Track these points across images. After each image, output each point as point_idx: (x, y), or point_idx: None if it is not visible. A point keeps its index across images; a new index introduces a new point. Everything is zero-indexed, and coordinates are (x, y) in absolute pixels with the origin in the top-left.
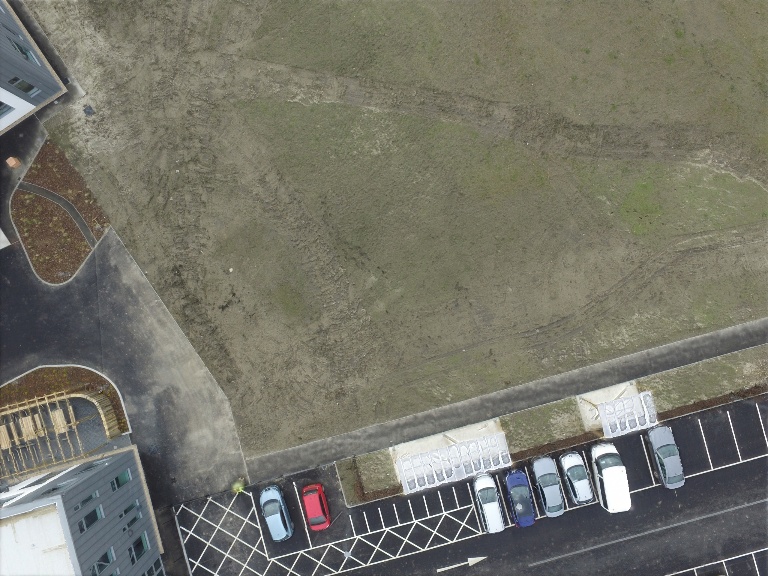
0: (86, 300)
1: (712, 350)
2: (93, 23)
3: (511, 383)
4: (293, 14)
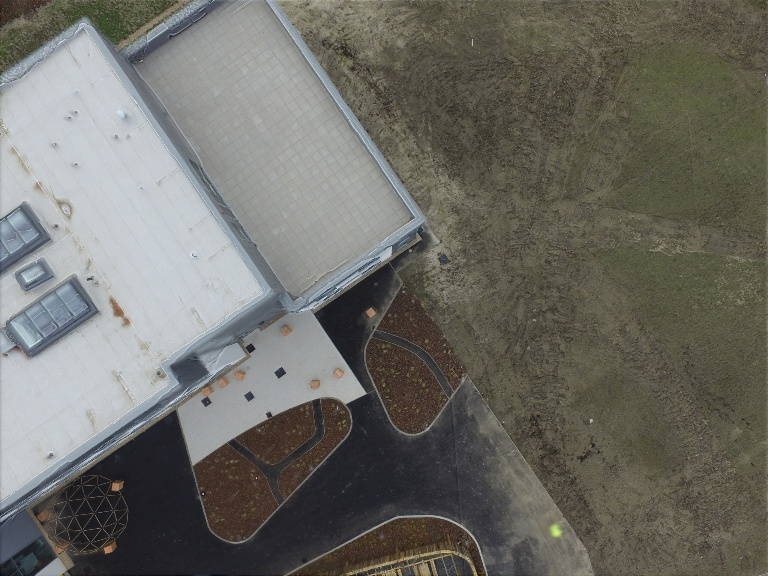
0: (443, 450)
1: None
2: (447, 171)
3: None
4: (654, 163)
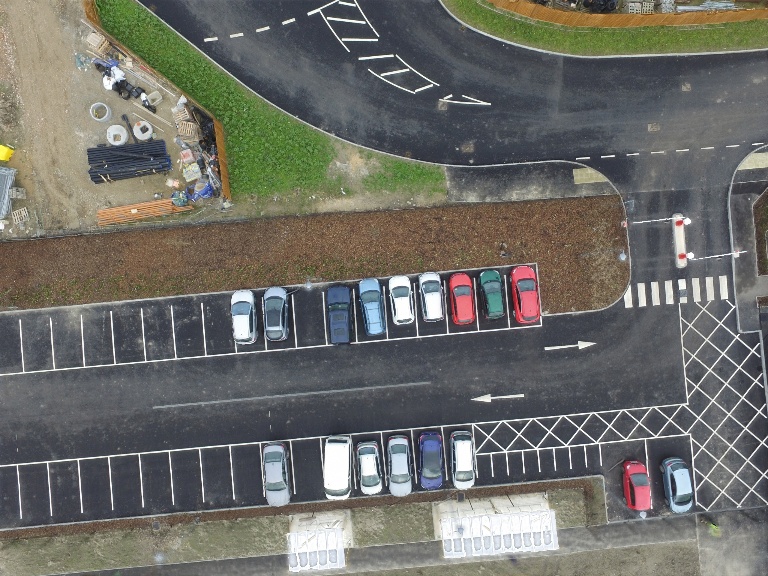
0: None
1: (208, 569)
2: None
3: (416, 572)
4: None
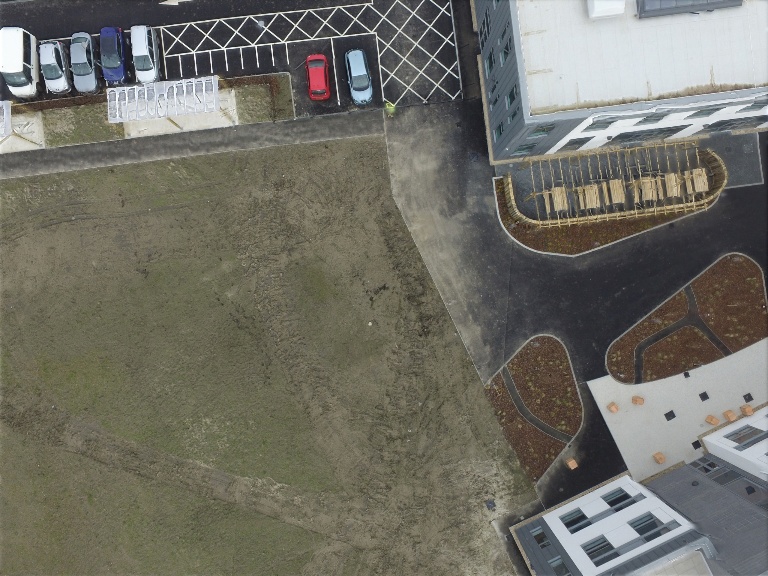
0: (519, 315)
1: None
2: None
3: (108, 171)
4: (269, 572)
